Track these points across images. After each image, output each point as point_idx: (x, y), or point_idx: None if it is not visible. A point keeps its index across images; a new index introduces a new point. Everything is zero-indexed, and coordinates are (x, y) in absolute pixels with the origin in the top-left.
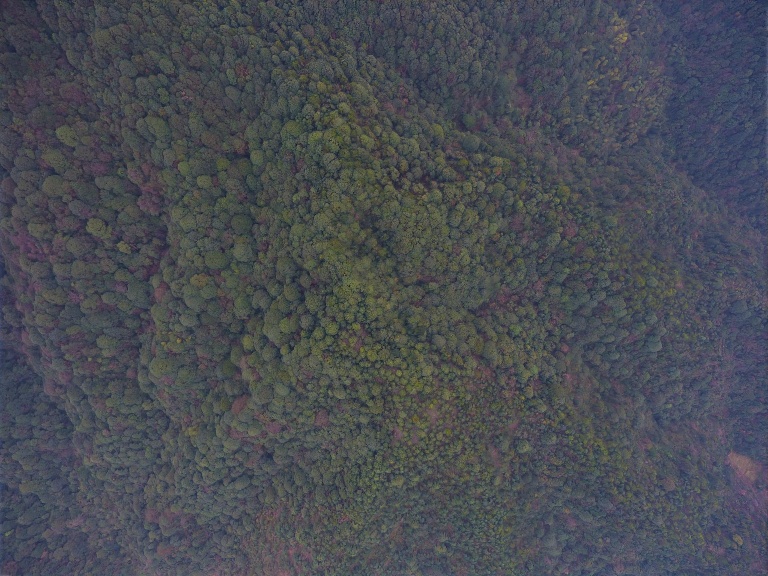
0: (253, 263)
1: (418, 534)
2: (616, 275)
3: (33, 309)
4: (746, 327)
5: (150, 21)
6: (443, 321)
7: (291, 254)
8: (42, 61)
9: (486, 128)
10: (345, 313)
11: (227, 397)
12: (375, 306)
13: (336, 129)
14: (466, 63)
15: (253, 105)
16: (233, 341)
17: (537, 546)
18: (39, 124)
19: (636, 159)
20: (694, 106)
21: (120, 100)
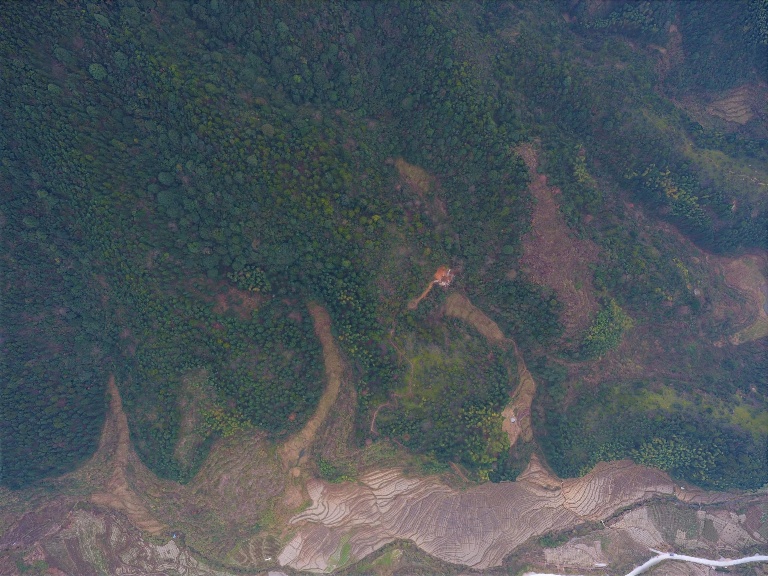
0: None
1: (9, 170)
2: None
3: None
4: (377, 4)
5: None
6: None
7: None
8: None
9: None
10: None
11: None
12: None
13: None
14: None
15: None
16: None
17: (150, 201)
18: None
19: None
20: None
21: None
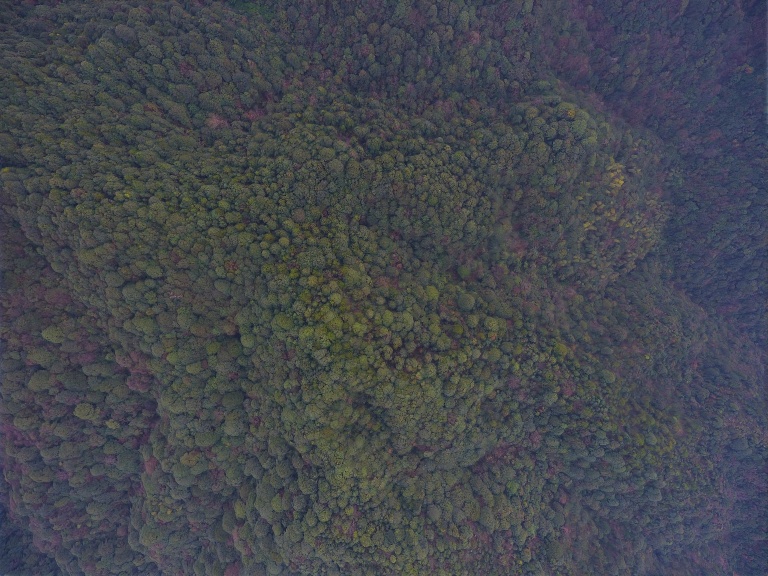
0: (245, 435)
1: None
2: (614, 434)
3: (20, 486)
4: (747, 461)
5: (136, 236)
6: (438, 489)
7: (283, 435)
8: (26, 274)
9: (481, 277)
10: (338, 500)
11: (219, 562)
12: (369, 487)
13: (327, 325)
14: (460, 226)
15: (243, 296)
16: (225, 503)
17: None
18: (24, 330)
19: (634, 292)
20: (692, 230)
21: (107, 304)
